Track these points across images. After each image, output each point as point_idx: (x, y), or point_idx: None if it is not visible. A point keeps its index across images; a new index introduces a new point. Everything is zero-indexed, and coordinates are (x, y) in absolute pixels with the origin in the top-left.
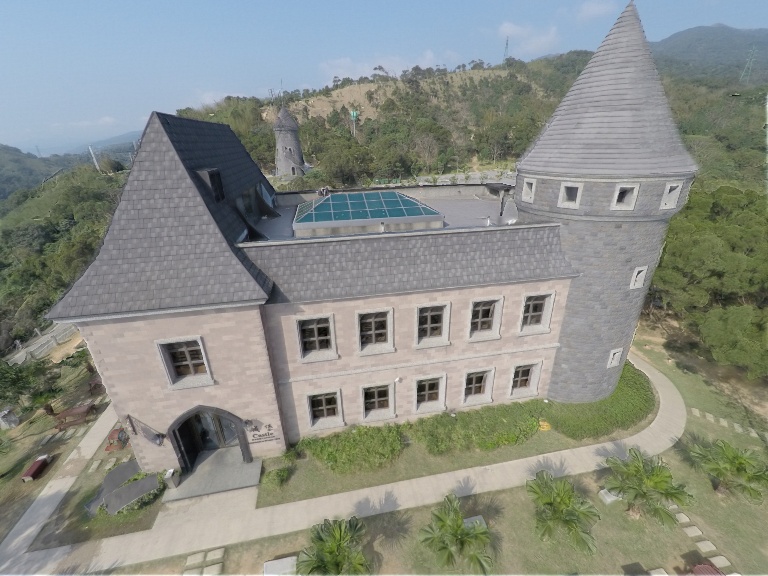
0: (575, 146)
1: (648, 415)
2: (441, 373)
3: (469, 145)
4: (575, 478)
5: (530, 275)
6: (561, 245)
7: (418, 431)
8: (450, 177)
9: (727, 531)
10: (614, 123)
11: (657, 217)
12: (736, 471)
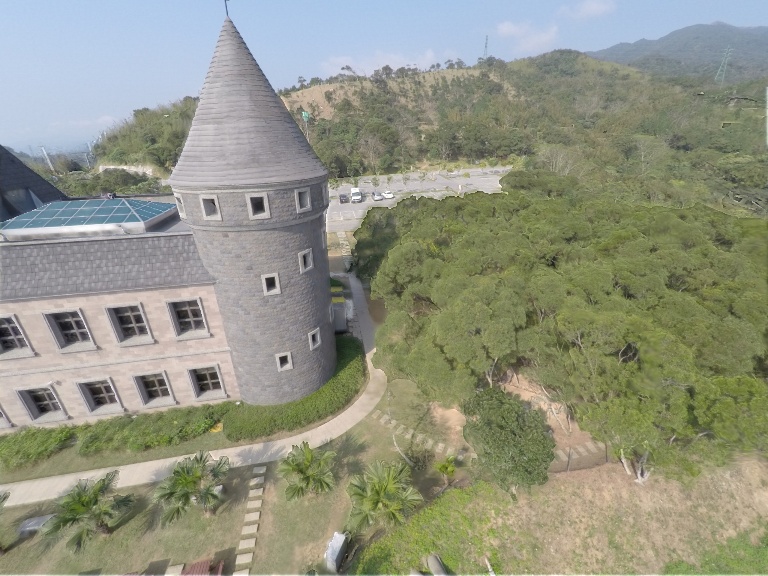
0: (181, 158)
1: (328, 417)
2: (104, 376)
3: (419, 145)
4: None
5: (159, 282)
6: (199, 253)
7: (89, 432)
8: (371, 178)
9: (283, 529)
10: (201, 137)
11: (258, 227)
12: None
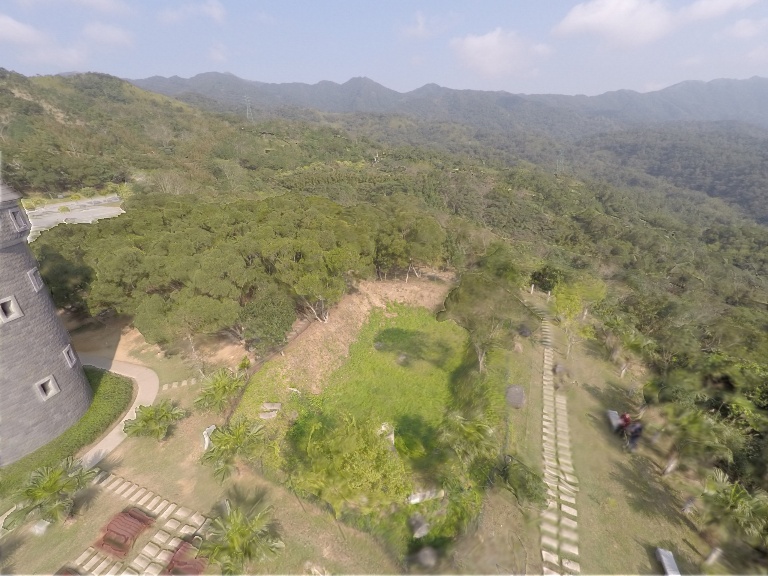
0: None
1: (121, 414)
2: None
3: None
4: (11, 535)
5: None
6: None
7: None
8: None
9: (160, 469)
10: None
11: None
12: (146, 423)
